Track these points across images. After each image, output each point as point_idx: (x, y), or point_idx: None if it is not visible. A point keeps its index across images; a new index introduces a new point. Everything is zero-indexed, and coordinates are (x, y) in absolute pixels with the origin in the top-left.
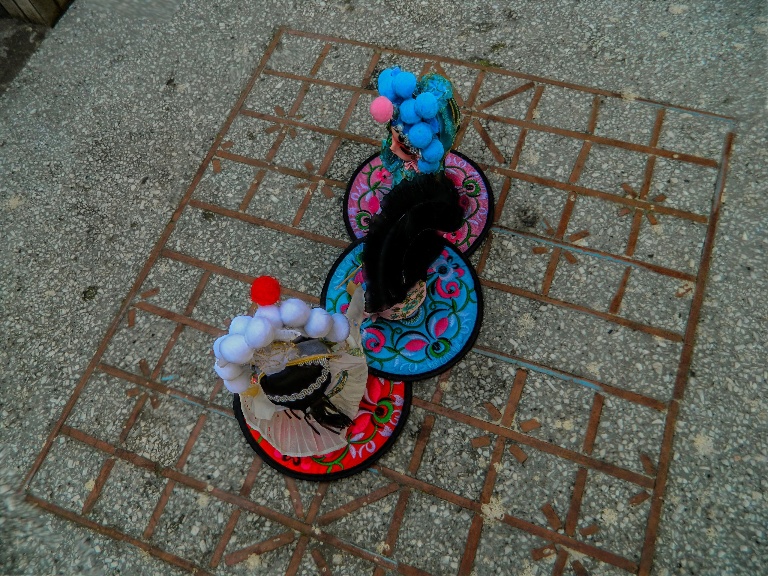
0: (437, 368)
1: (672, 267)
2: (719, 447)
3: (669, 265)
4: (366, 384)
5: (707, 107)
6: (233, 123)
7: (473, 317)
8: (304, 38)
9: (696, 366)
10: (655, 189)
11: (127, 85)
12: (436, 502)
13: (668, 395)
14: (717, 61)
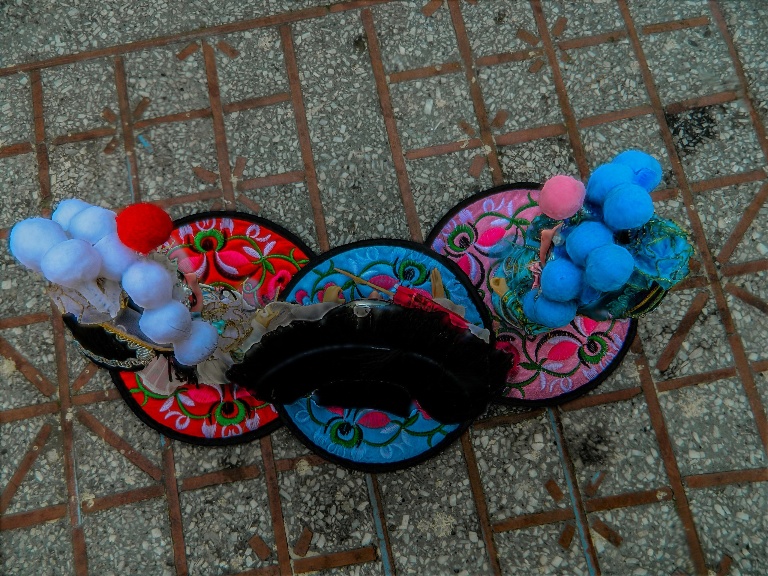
0: (318, 446)
1: None
2: None
3: None
4: None
5: None
6: None
7: (409, 454)
8: None
9: None
10: None
11: None
12: (165, 532)
13: None
14: None
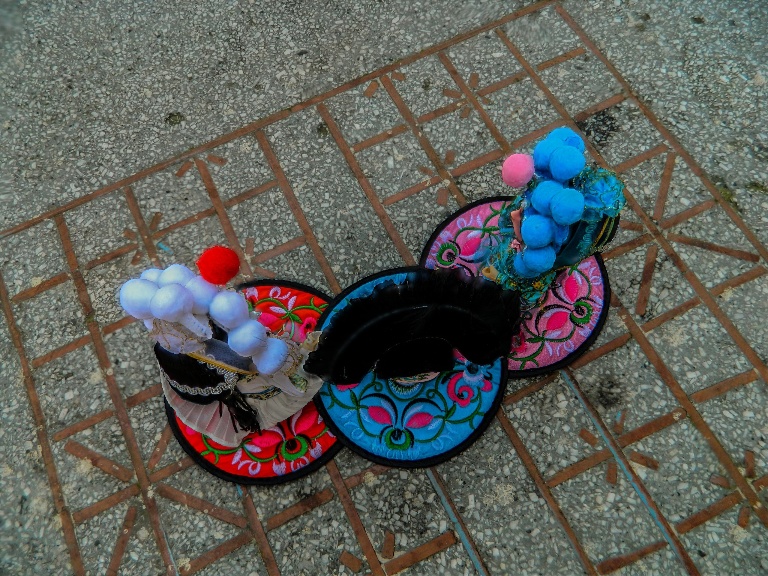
0: (378, 455)
1: None
2: None
3: None
4: (303, 409)
5: None
6: (423, 59)
7: (457, 440)
8: (565, 24)
9: None
10: None
11: None
12: (262, 573)
13: None
14: None
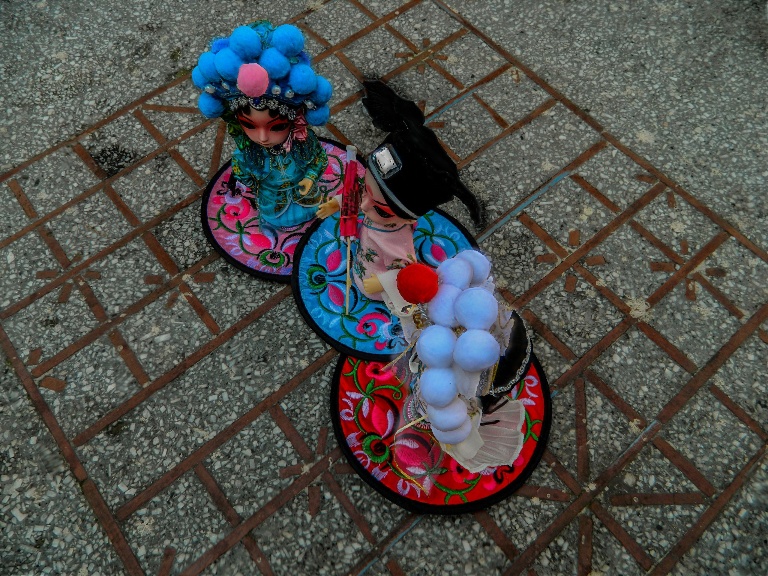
0: None
1: (491, 70)
2: (652, 129)
3: (488, 71)
4: None
5: None
6: (9, 334)
7: (447, 223)
8: None
9: (582, 105)
10: (416, 40)
11: None
12: (611, 352)
13: (596, 134)
14: None
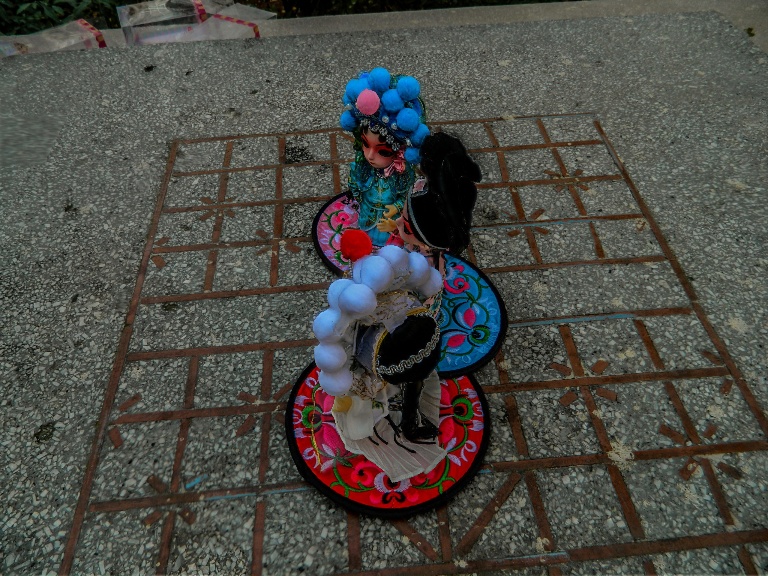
0: (489, 351)
1: (621, 213)
2: (750, 322)
3: (618, 212)
4: None
5: (568, 111)
6: (160, 222)
7: (493, 299)
8: (203, 143)
9: (689, 272)
10: (570, 168)
11: (15, 223)
12: (564, 472)
13: (686, 300)
14: (554, 85)
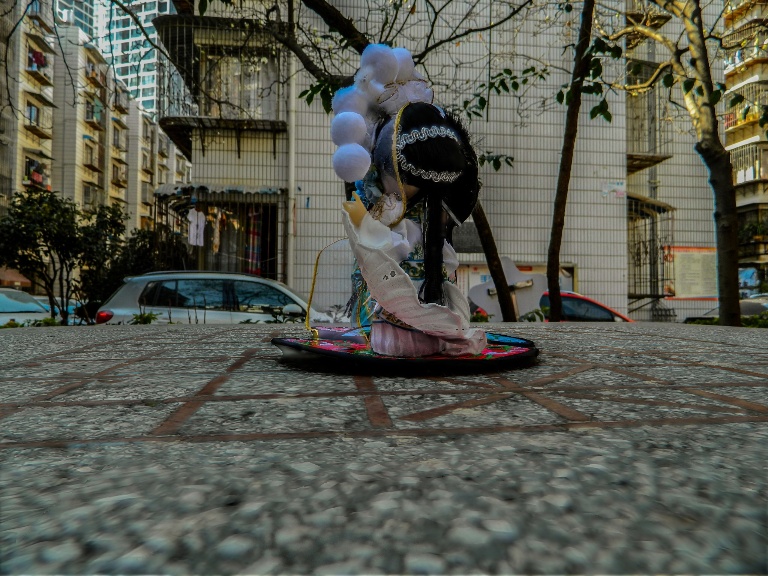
0: (518, 342)
1: None
2: None
3: None
4: None
5: None
6: None
7: None
8: None
9: None
10: None
11: None
12: None
13: None
14: None
